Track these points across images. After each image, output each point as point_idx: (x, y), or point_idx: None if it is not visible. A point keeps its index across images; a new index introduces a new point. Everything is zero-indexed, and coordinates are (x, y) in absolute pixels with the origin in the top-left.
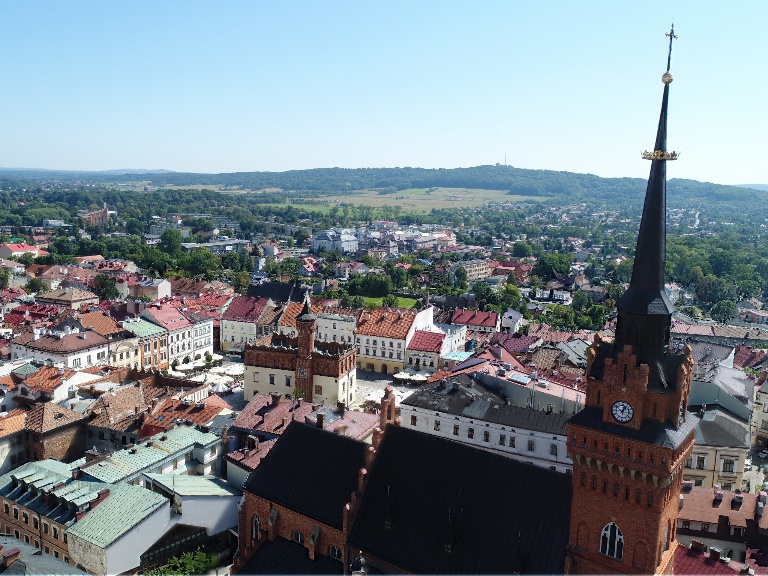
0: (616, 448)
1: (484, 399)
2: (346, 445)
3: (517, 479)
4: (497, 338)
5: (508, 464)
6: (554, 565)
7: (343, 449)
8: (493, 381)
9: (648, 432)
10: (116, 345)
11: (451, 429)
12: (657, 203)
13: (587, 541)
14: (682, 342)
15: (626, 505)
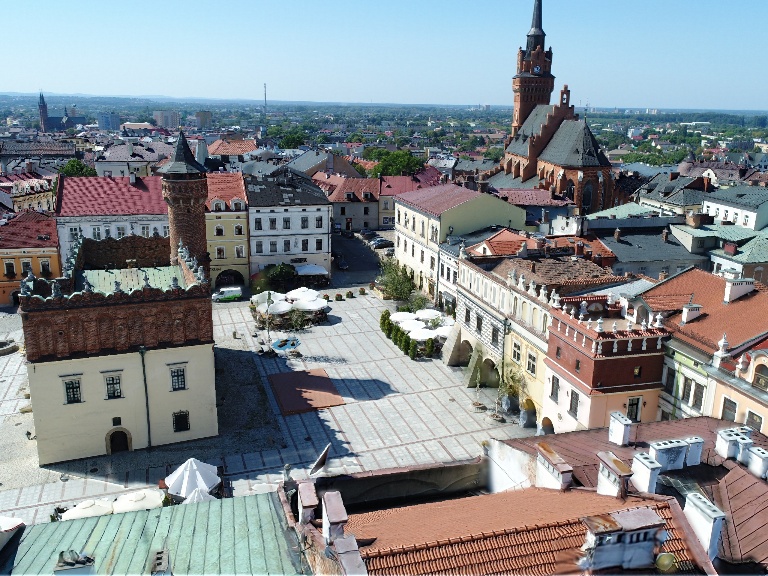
0: None
1: None
2: None
3: None
4: None
5: None
6: None
7: None
8: None
9: None
10: (449, 479)
11: None
12: None
13: None
14: None
15: None
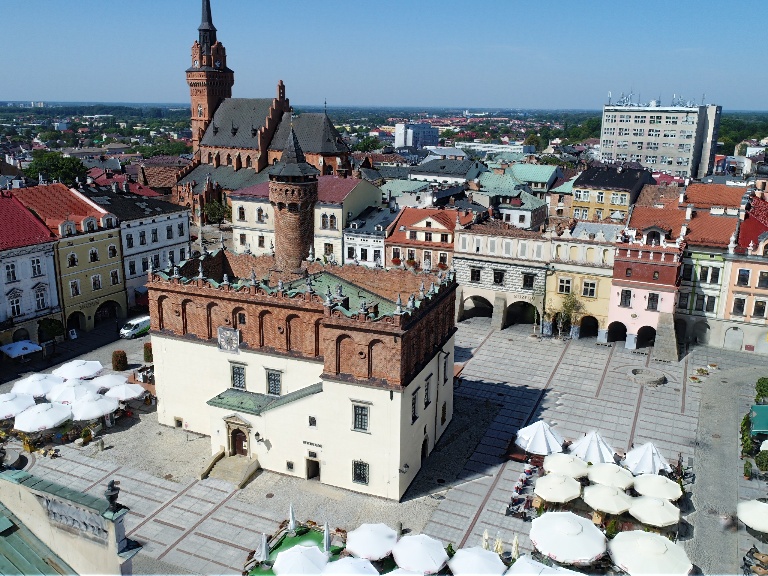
0: None
1: None
2: None
3: None
4: None
5: None
6: None
7: None
8: None
9: None
10: None
11: None
12: None
13: None
14: None
15: None
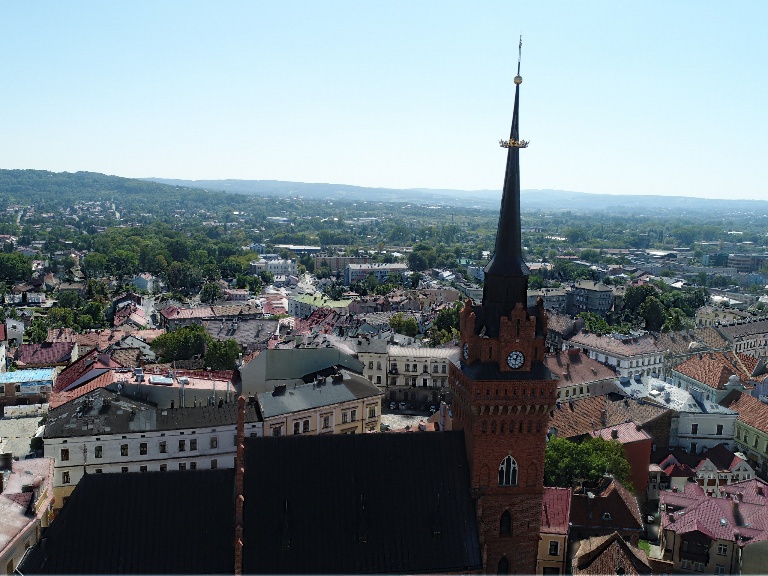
0: (514, 391)
1: (139, 410)
2: (184, 480)
3: (405, 450)
4: (22, 351)
5: (392, 439)
6: (464, 512)
7: (181, 486)
8: (136, 389)
9: (537, 372)
10: None
11: (118, 451)
12: (517, 183)
13: (488, 480)
14: (234, 322)
15: (520, 437)
